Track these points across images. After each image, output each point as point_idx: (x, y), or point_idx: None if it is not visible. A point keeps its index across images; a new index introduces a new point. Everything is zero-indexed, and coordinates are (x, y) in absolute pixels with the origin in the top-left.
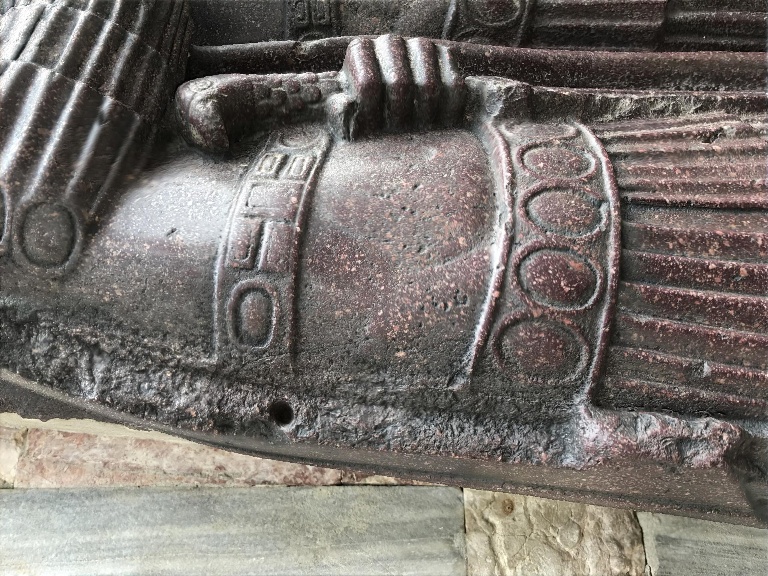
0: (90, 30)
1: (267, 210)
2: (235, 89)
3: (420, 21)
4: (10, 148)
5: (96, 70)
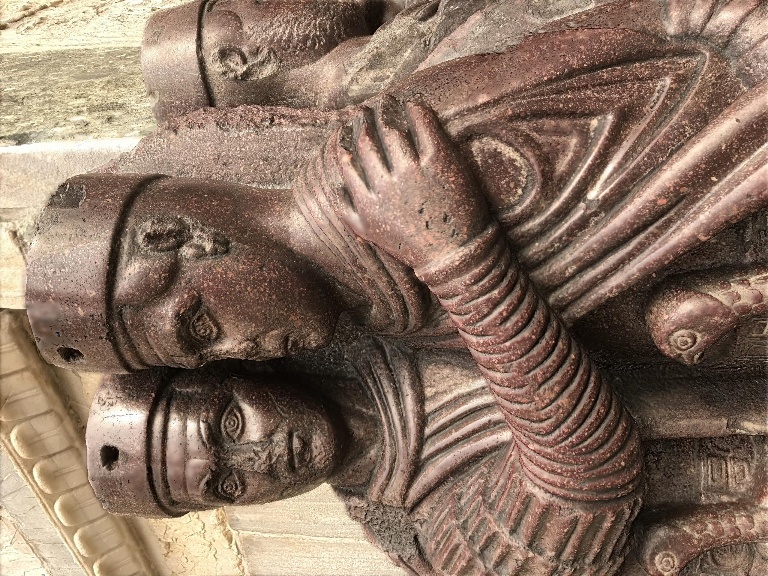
0: (593, 575)
1: None
2: None
3: None
4: None
5: None
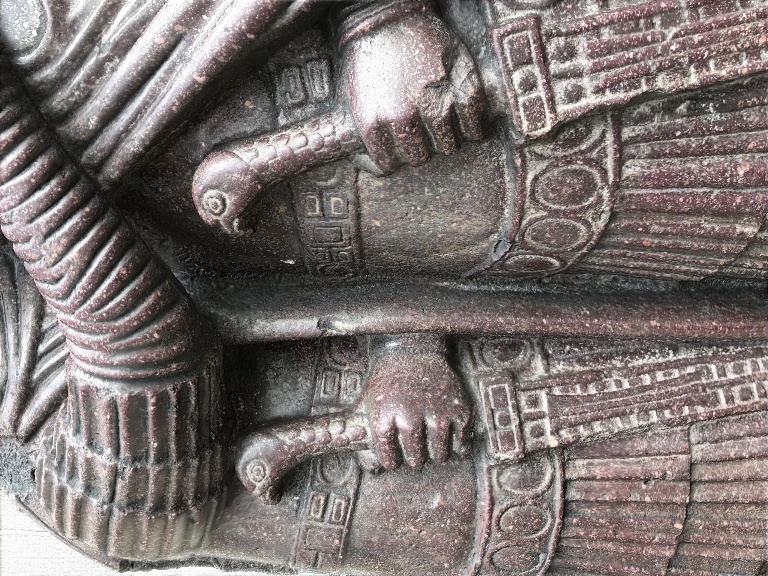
0: (162, 479)
1: (319, 548)
2: None
3: (450, 265)
4: None
5: (177, 496)
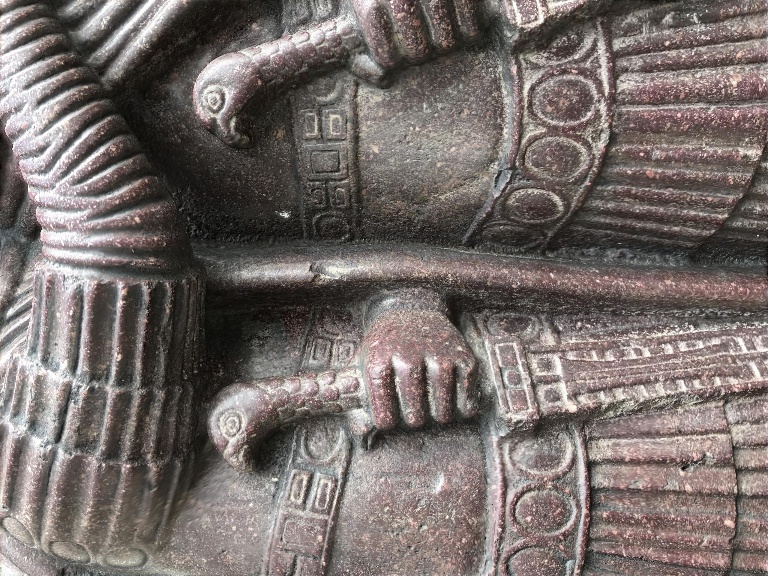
0: (121, 408)
1: (298, 547)
2: (262, 424)
3: (450, 212)
4: (80, 521)
5: (135, 442)
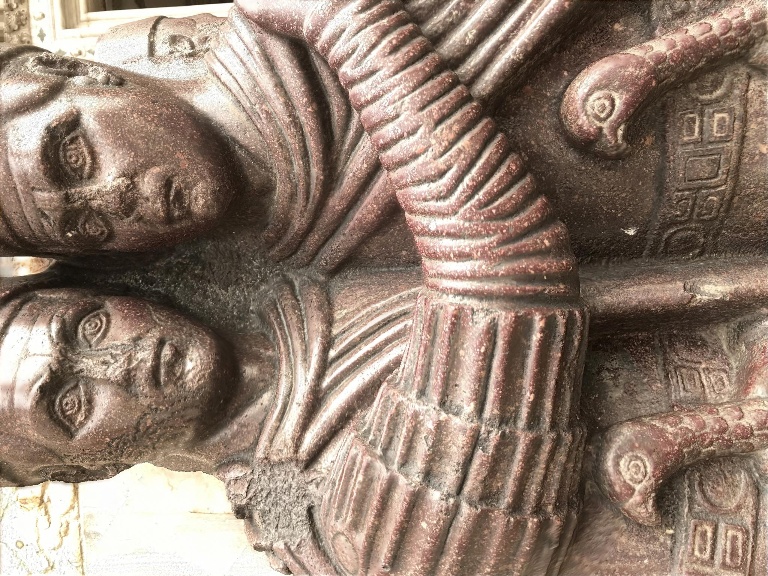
0: (531, 455)
1: None
2: (669, 468)
3: None
4: None
5: None
